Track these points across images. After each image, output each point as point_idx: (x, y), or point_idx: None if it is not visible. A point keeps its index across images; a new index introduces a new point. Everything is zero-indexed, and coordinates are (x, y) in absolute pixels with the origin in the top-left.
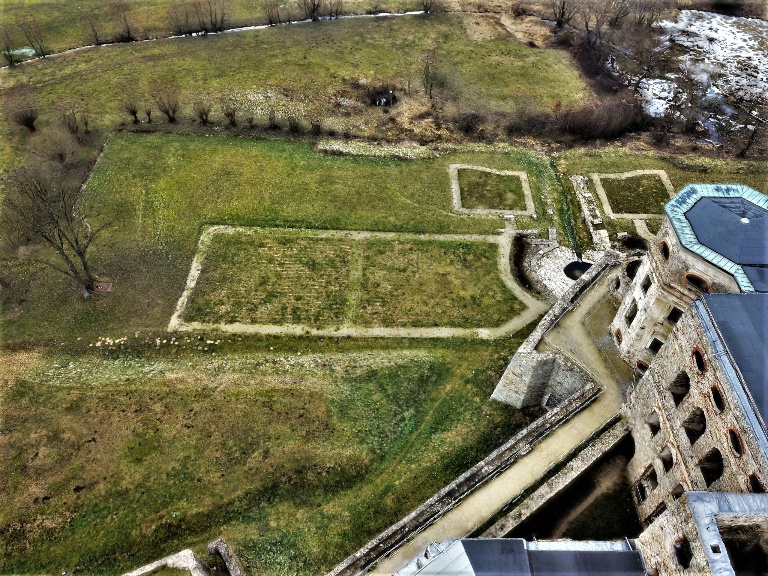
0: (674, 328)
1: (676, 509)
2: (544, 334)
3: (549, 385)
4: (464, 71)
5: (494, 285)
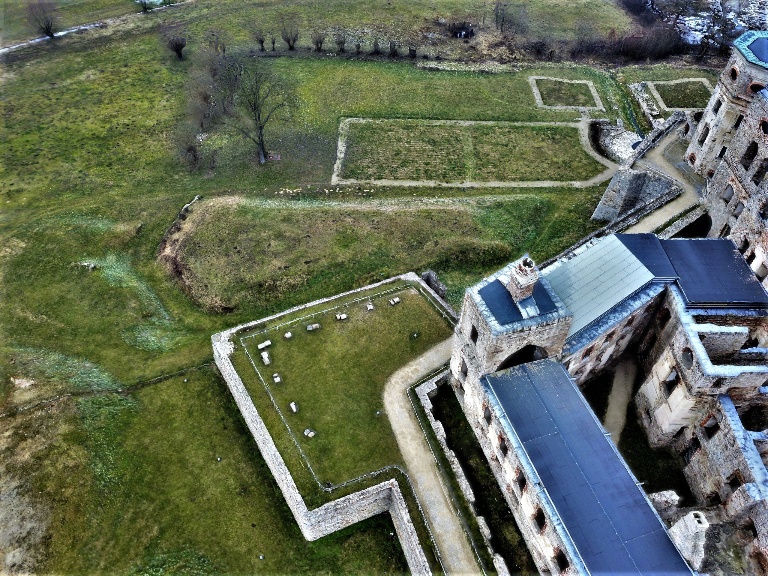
0: (744, 117)
1: (760, 187)
2: (636, 160)
3: (640, 199)
4: (527, 11)
5: (579, 154)
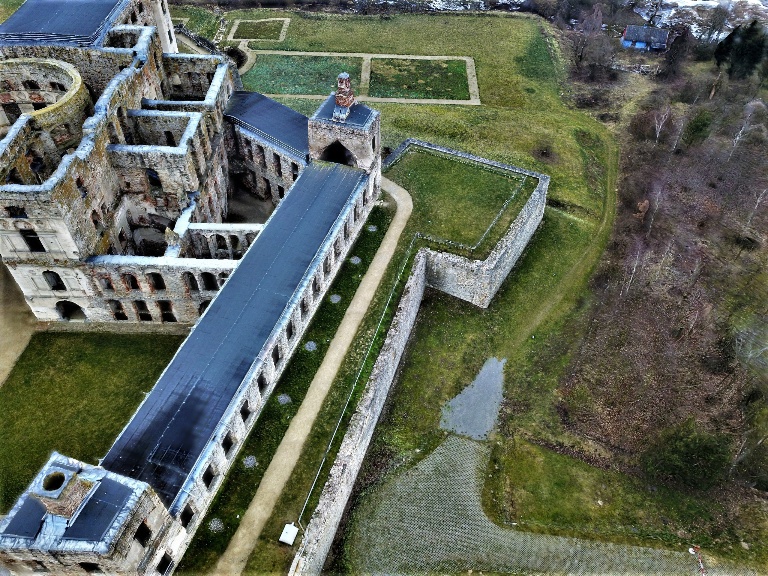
0: None
1: None
2: None
3: None
4: None
5: None
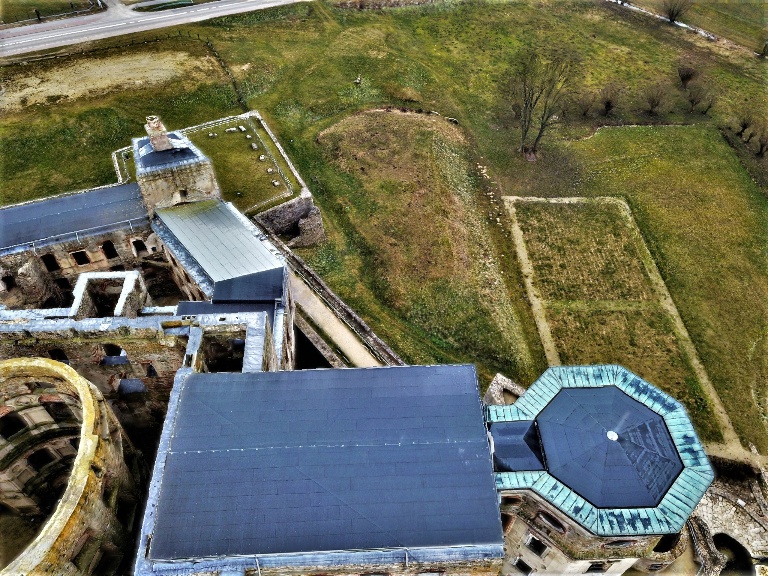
0: None
1: None
2: None
3: None
4: None
5: None
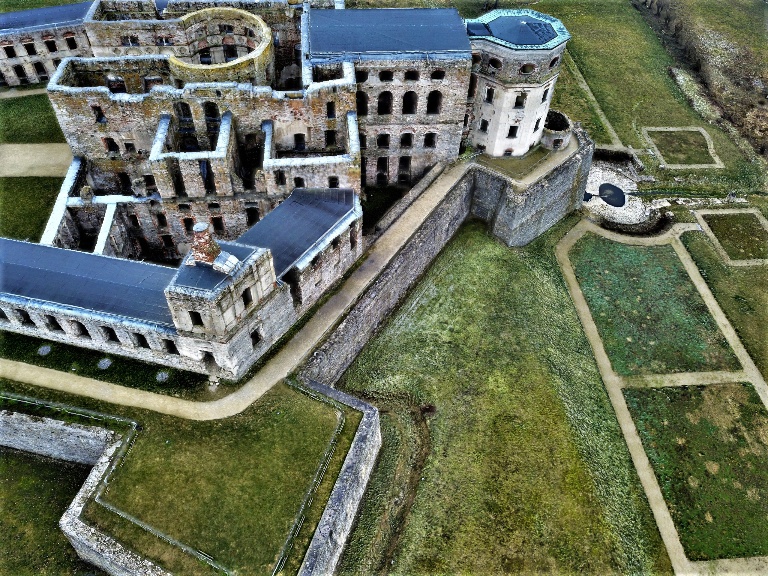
0: None
1: None
2: None
3: None
4: None
5: None
